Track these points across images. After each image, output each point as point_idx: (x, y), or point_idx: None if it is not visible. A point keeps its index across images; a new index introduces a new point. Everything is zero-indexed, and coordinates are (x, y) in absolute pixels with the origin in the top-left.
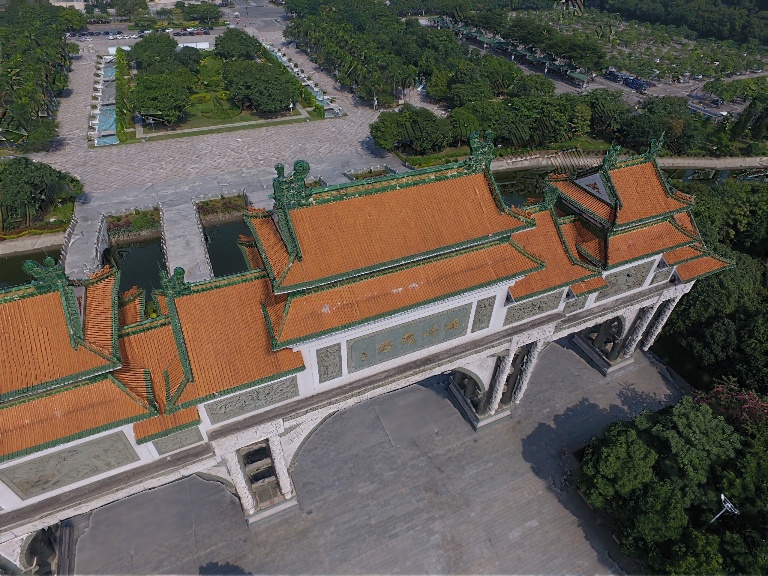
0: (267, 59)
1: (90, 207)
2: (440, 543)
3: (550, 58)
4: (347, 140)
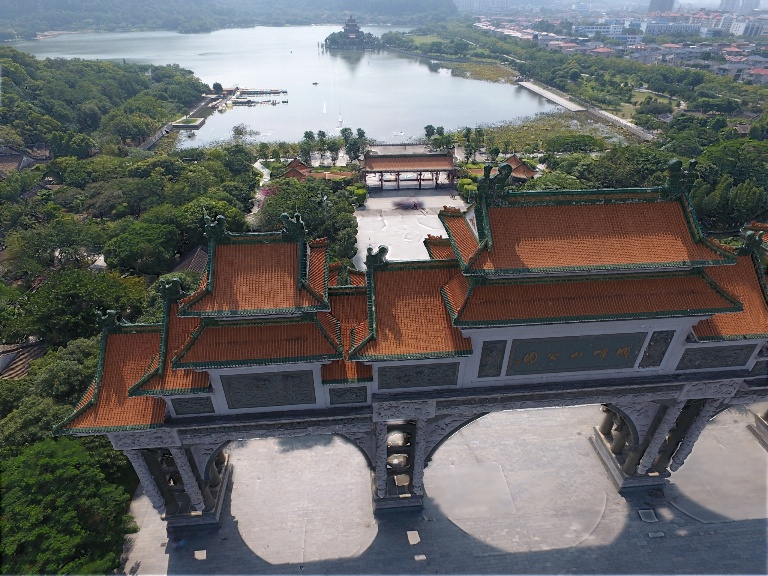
0: None
1: None
2: None
3: None
4: None
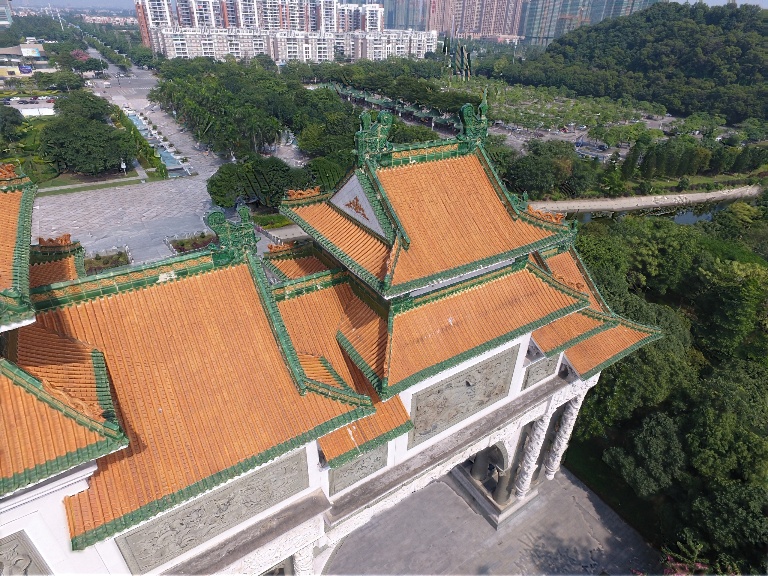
0: (122, 122)
1: None
2: None
3: (436, 113)
4: (186, 201)
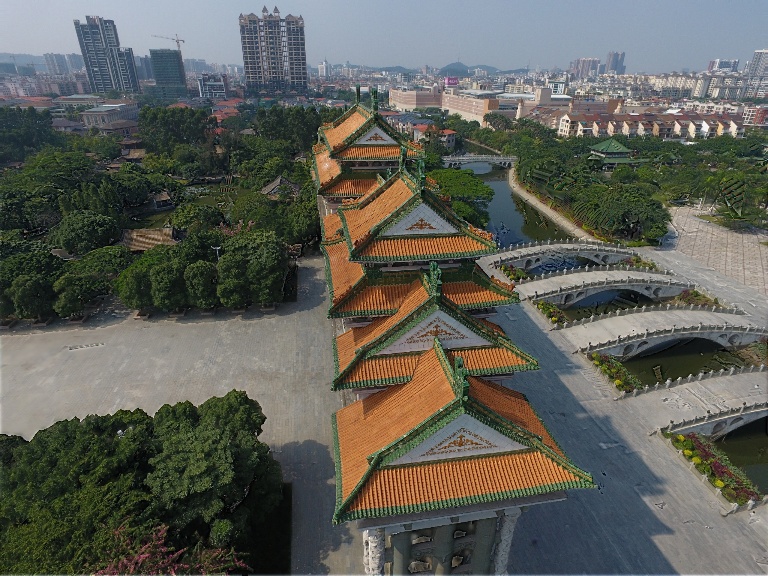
0: None
1: (650, 251)
2: (279, 371)
3: None
4: None
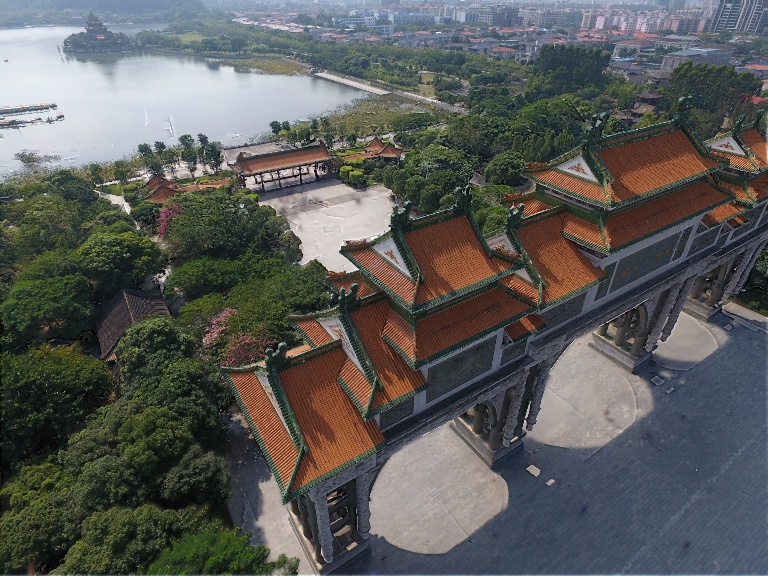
0: None
1: None
2: None
3: None
4: None
